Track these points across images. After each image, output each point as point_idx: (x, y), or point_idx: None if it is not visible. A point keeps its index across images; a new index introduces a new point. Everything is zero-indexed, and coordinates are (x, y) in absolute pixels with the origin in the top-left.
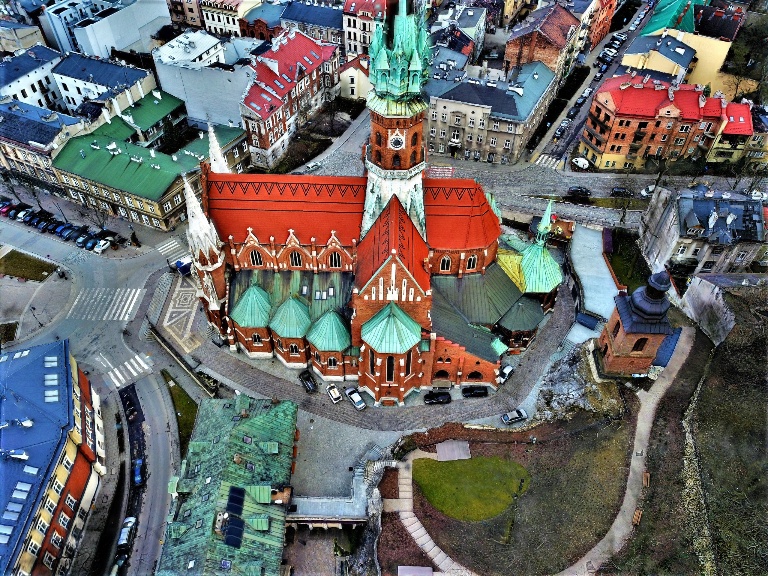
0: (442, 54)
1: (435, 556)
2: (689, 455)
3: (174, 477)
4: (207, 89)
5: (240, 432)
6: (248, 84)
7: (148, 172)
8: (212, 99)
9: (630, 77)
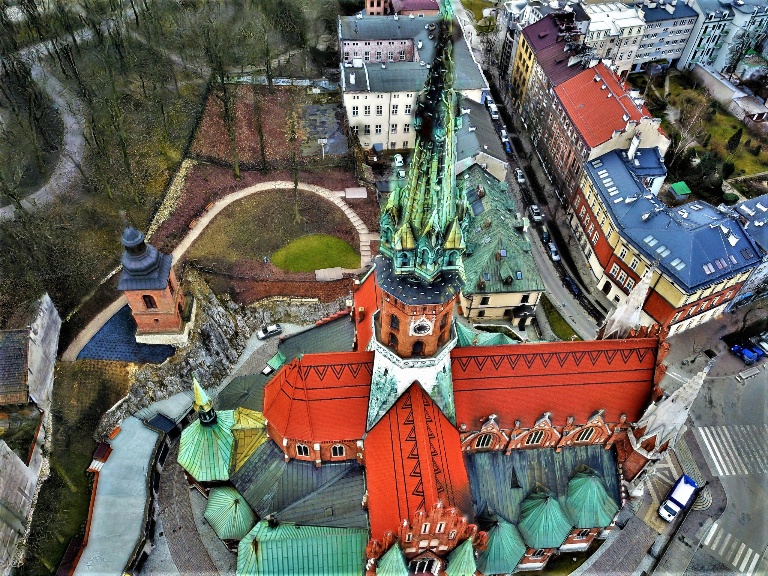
0: None
1: (344, 205)
2: (157, 224)
3: (528, 224)
4: None
5: (495, 239)
6: None
7: None
8: None
9: None
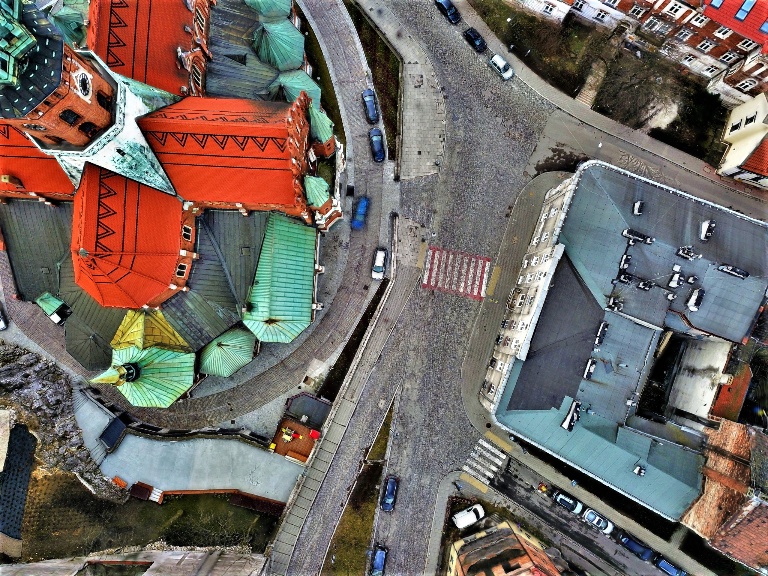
0: (735, 284)
1: None
2: None
3: None
4: None
5: None
6: None
7: None
8: None
9: None
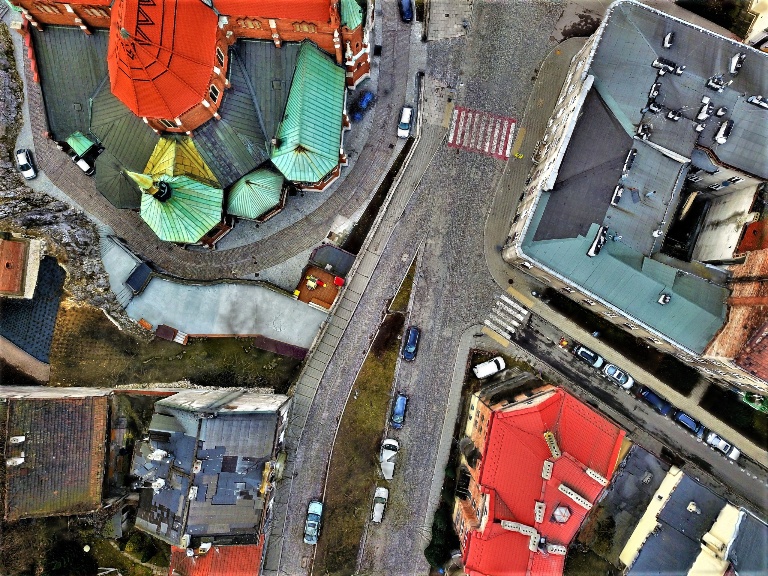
0: (764, 117)
1: None
2: None
3: None
4: None
5: None
6: None
7: None
8: None
9: (584, 464)
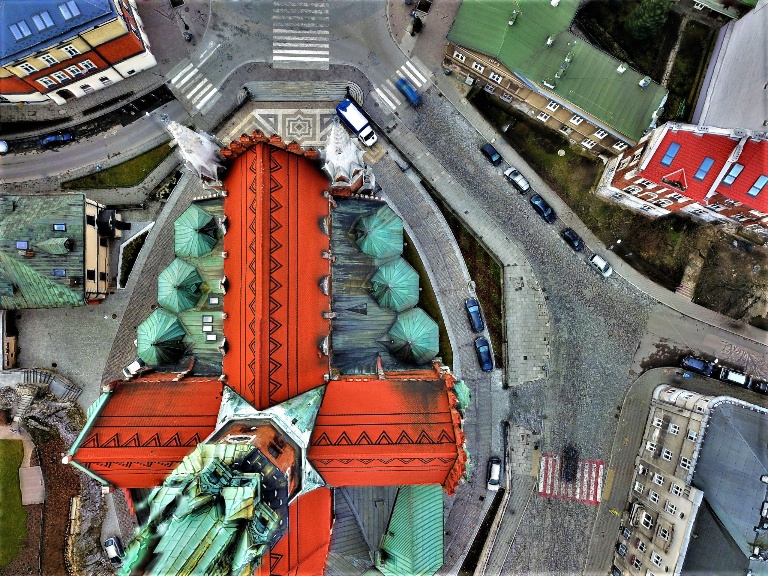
0: None
1: None
2: None
3: None
4: (764, 45)
5: None
6: (731, 129)
7: (503, 8)
8: (749, 59)
9: None
